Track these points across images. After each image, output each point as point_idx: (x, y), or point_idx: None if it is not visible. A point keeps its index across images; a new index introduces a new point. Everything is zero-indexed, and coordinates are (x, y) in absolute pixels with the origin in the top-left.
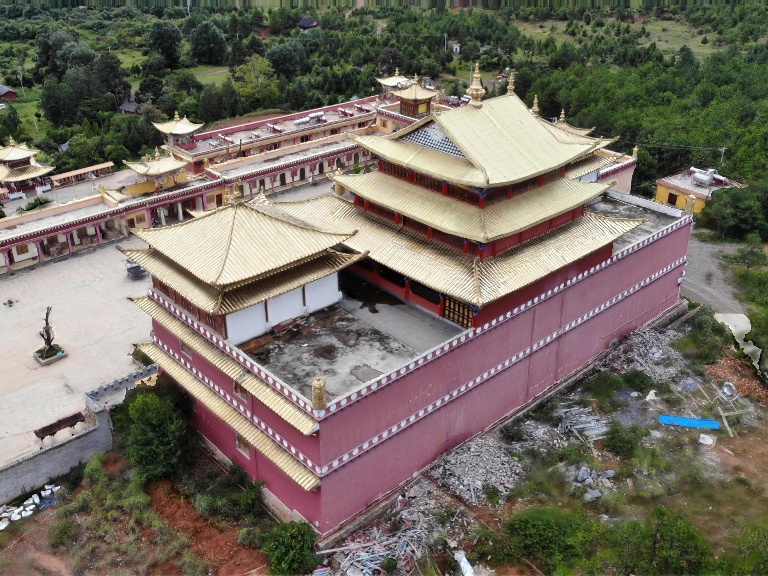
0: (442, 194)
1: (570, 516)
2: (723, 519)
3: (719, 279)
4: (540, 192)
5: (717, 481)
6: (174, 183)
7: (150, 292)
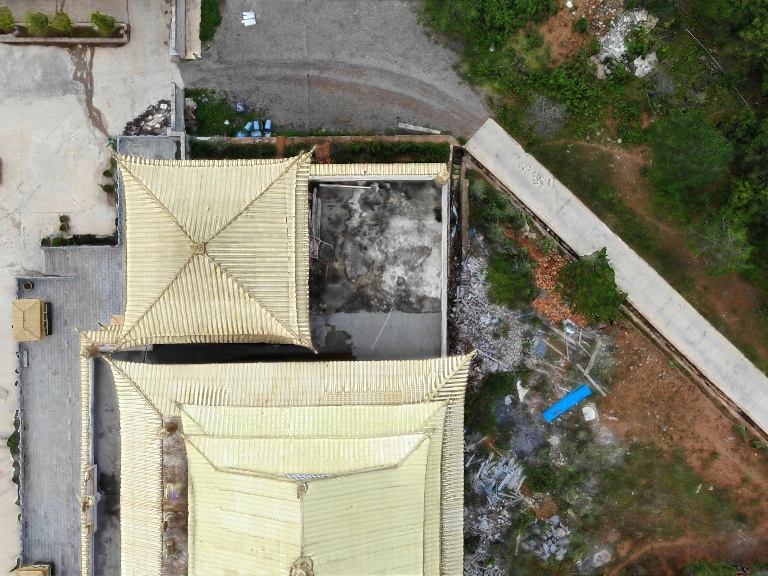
0: None
1: None
2: (646, 499)
3: (420, 37)
4: None
5: (622, 460)
6: None
7: None
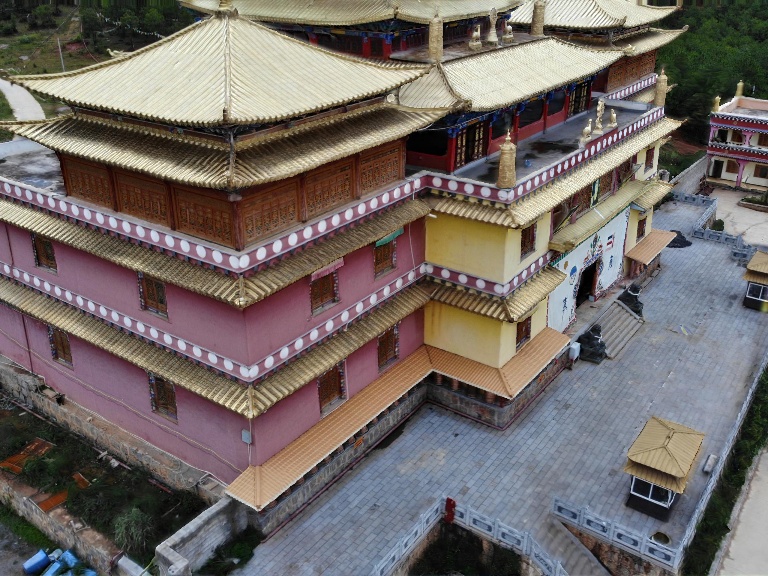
0: None
1: None
2: None
3: None
4: None
5: None
6: None
7: None
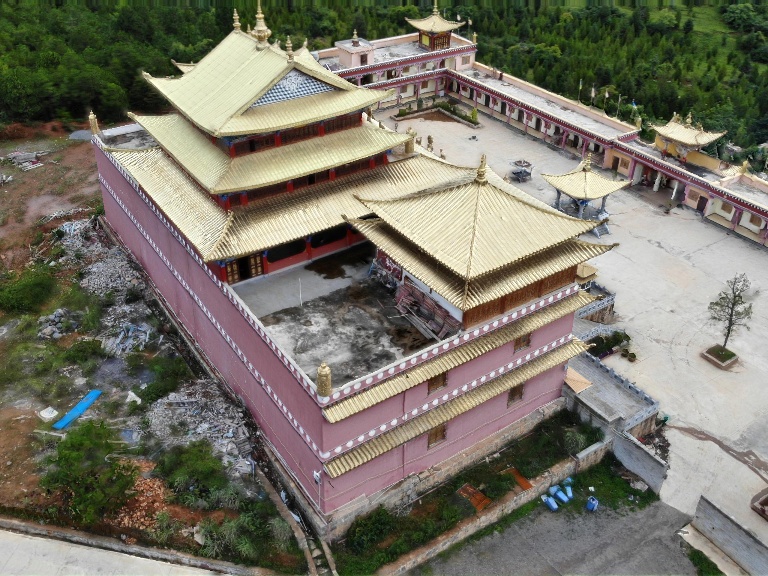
0: None
1: (23, 292)
2: None
3: None
4: (207, 145)
5: None
6: (701, 164)
7: None
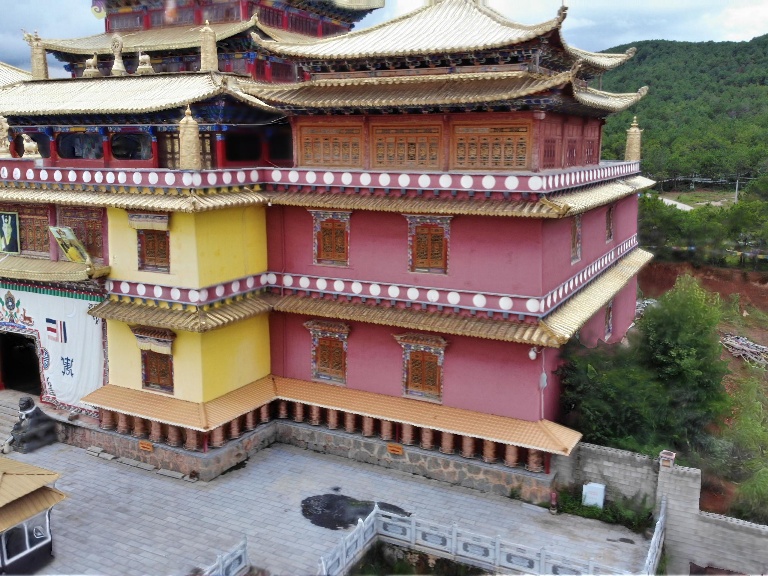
0: (319, 37)
1: None
2: None
3: None
4: None
5: None
6: None
7: (544, 183)
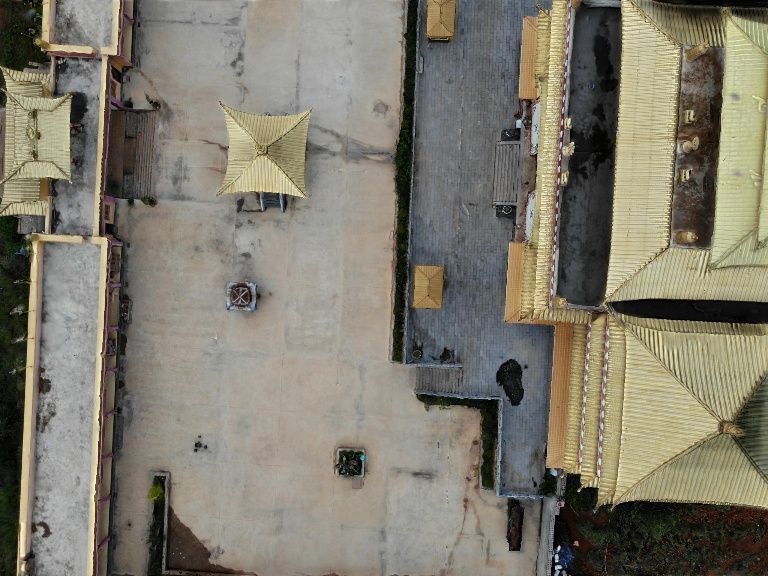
0: None
1: None
2: None
3: None
4: None
5: None
6: None
7: None
